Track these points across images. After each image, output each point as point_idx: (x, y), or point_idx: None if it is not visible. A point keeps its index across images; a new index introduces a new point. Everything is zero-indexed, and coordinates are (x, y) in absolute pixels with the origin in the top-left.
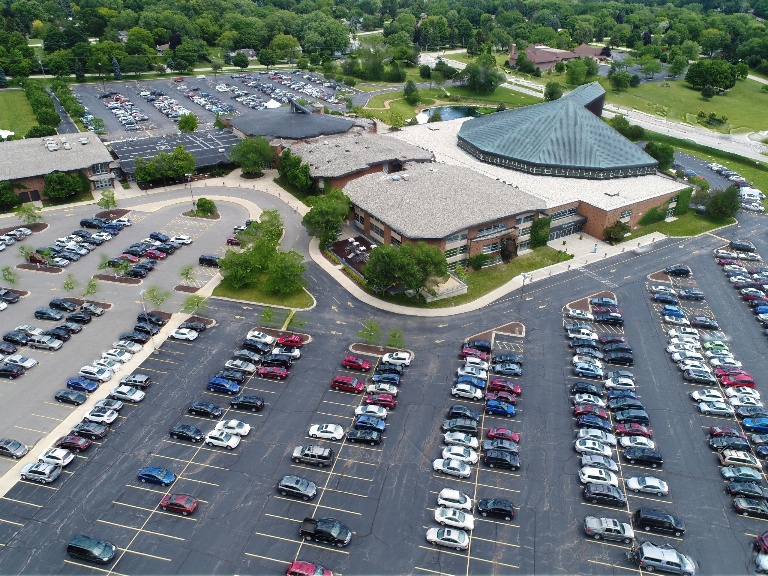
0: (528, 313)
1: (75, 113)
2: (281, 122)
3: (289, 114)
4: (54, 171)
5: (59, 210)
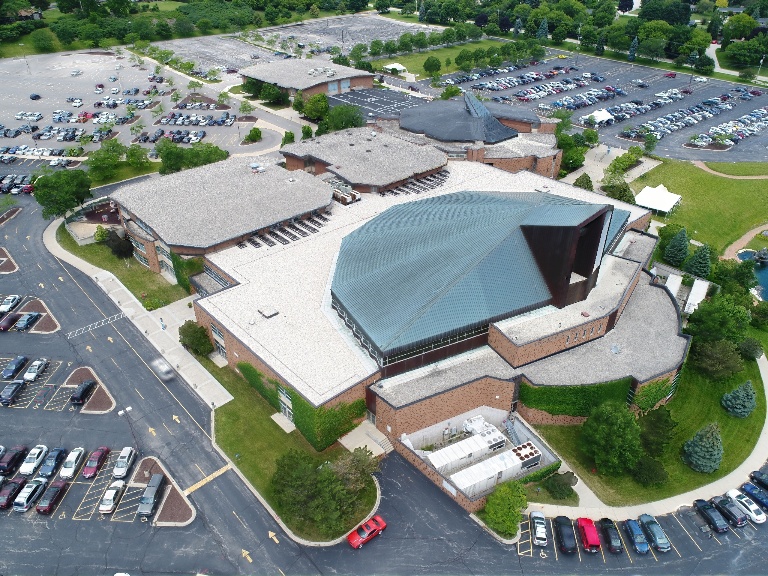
0: (32, 276)
1: (461, 68)
2: (436, 111)
3: (460, 109)
4: (276, 83)
5: (255, 107)
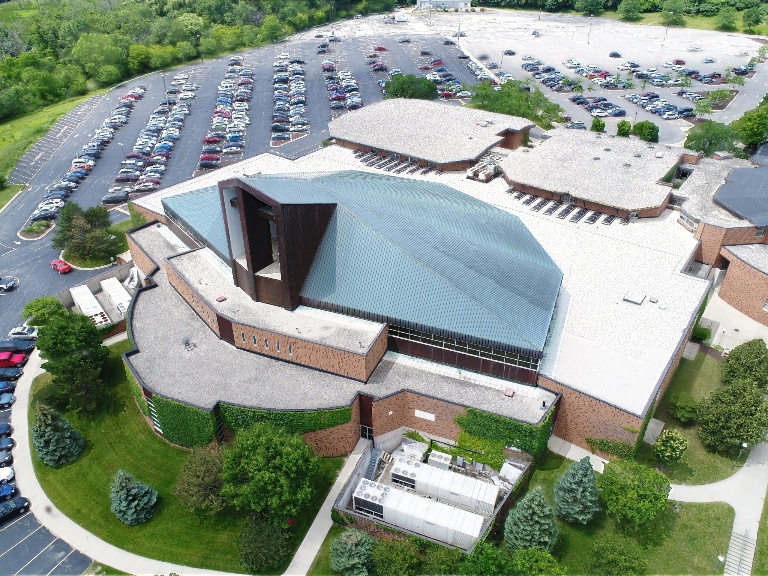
0: None
1: None
2: None
3: None
4: None
5: None
